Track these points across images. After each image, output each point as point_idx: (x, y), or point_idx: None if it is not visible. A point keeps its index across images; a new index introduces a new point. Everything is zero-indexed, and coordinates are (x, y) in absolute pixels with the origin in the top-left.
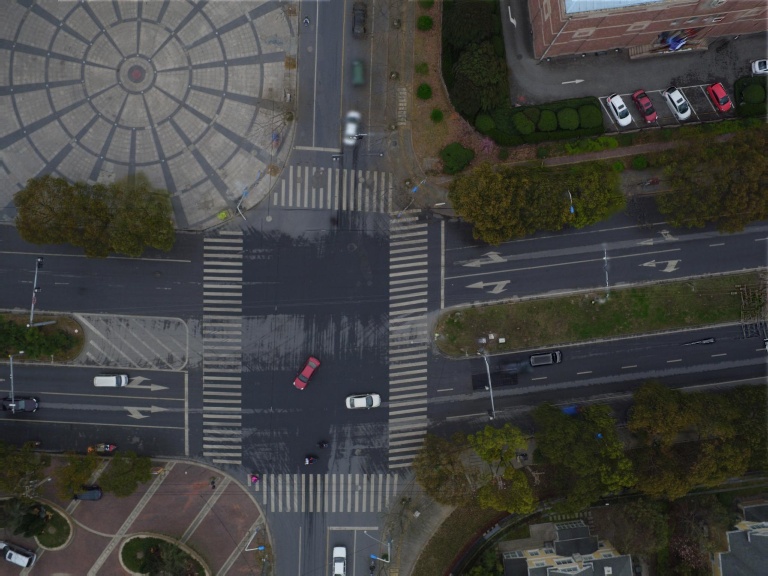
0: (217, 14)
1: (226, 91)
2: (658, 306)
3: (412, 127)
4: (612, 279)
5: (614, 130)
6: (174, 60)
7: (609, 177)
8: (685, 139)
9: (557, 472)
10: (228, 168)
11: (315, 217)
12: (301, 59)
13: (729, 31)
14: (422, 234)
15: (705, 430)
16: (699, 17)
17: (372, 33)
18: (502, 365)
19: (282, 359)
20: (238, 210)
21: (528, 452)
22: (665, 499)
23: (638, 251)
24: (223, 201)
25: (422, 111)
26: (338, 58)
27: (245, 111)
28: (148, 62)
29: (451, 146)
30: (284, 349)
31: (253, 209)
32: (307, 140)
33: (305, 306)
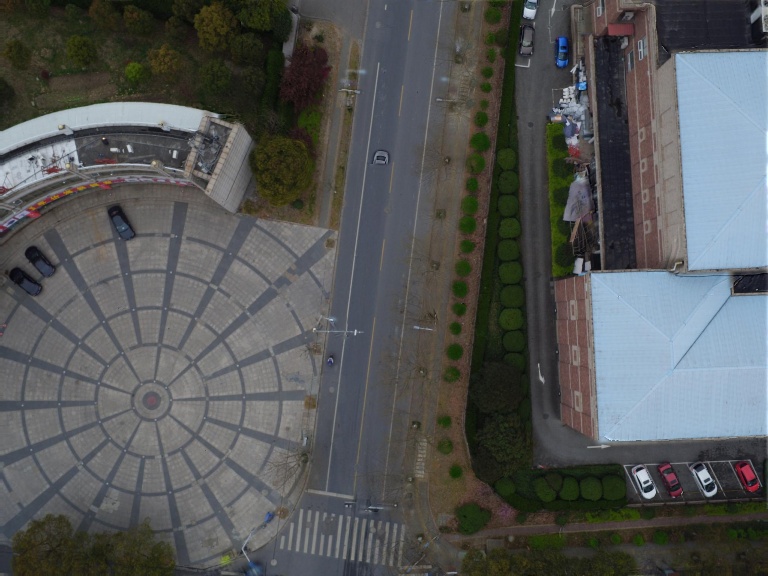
0: (240, 346)
1: (242, 426)
2: None
3: (430, 480)
4: None
5: (637, 500)
6: (191, 389)
7: (628, 548)
8: (709, 515)
9: None
10: (236, 506)
11: (321, 565)
12: (322, 399)
13: None
14: None
15: None
16: None
17: (397, 378)
18: None
19: None
20: (243, 551)
21: None
22: None
23: None
24: (228, 540)
25: (441, 464)
26: (360, 402)
27: (259, 448)
28: (164, 389)
29: (468, 506)
30: None
31: (258, 551)
32: (320, 484)
33: None
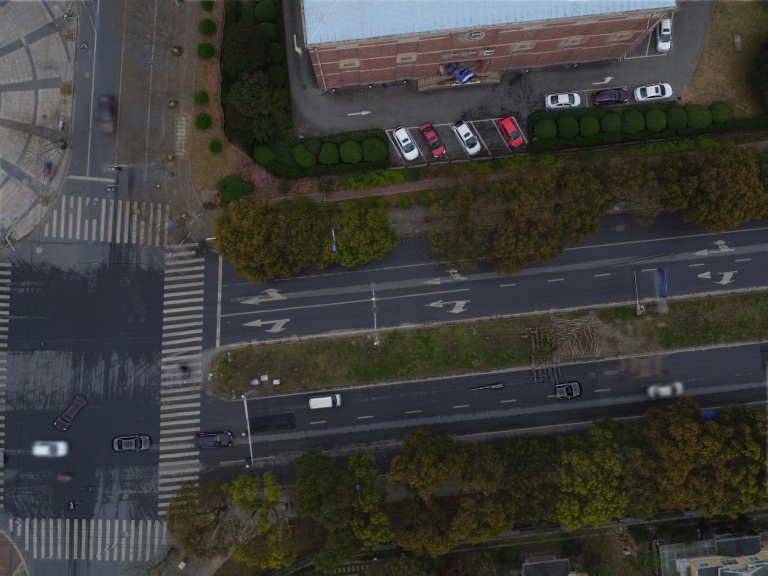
0: None
1: None
2: (444, 349)
3: (190, 158)
4: (396, 319)
5: (401, 164)
6: None
7: (395, 213)
8: (475, 175)
9: (308, 525)
10: None
11: (87, 249)
12: (77, 85)
13: (513, 64)
14: (199, 269)
15: (469, 483)
16: (462, 50)
17: (152, 60)
18: (277, 408)
19: (48, 397)
20: (7, 241)
21: (288, 502)
22: (427, 556)
23: (424, 291)
24: None
25: (201, 141)
26: (116, 85)
27: (18, 138)
28: None
29: (228, 178)
30: (51, 387)
31: (23, 240)
32: (81, 169)
33: (74, 342)
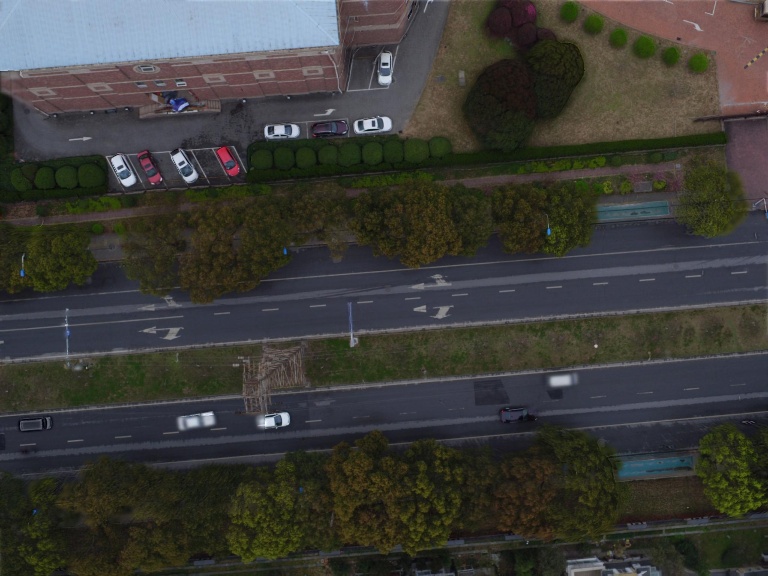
0: None
1: None
2: (155, 375)
3: None
4: (109, 344)
5: (119, 190)
6: None
7: (112, 238)
8: (193, 203)
9: None
10: None
11: None
12: None
13: (221, 95)
14: None
15: (145, 512)
16: (145, 82)
17: None
18: None
19: None
20: None
21: None
22: None
23: (138, 316)
24: None
25: None
26: None
27: None
28: None
29: None
30: None
31: None
32: None
33: None
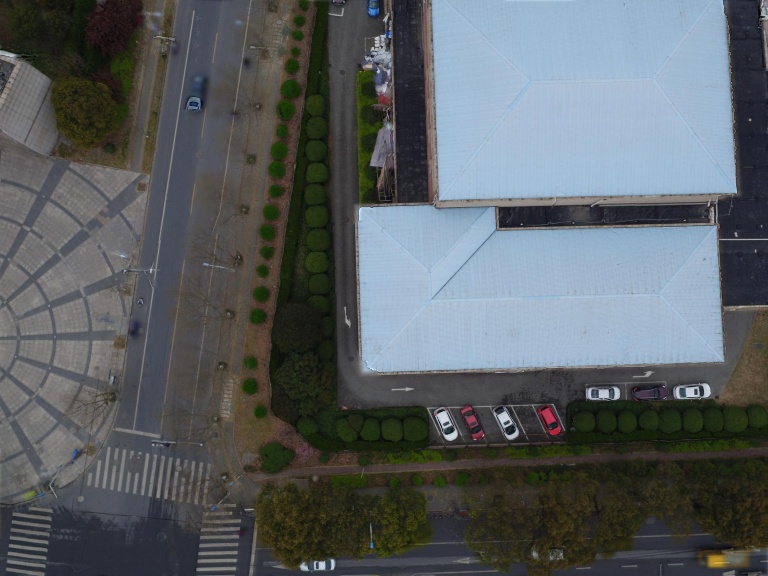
0: (51, 287)
1: (52, 365)
2: None
3: (235, 420)
4: None
5: (440, 443)
6: (3, 329)
7: (430, 490)
8: (511, 458)
9: None
10: (45, 443)
11: (127, 502)
12: (131, 340)
13: None
14: (234, 530)
15: None
16: None
17: (205, 320)
18: None
19: None
20: (50, 488)
21: None
22: None
23: (453, 569)
24: (36, 477)
25: (247, 405)
26: (168, 342)
27: (69, 387)
28: None
29: (271, 445)
30: None
31: (66, 488)
32: (128, 422)
33: None
